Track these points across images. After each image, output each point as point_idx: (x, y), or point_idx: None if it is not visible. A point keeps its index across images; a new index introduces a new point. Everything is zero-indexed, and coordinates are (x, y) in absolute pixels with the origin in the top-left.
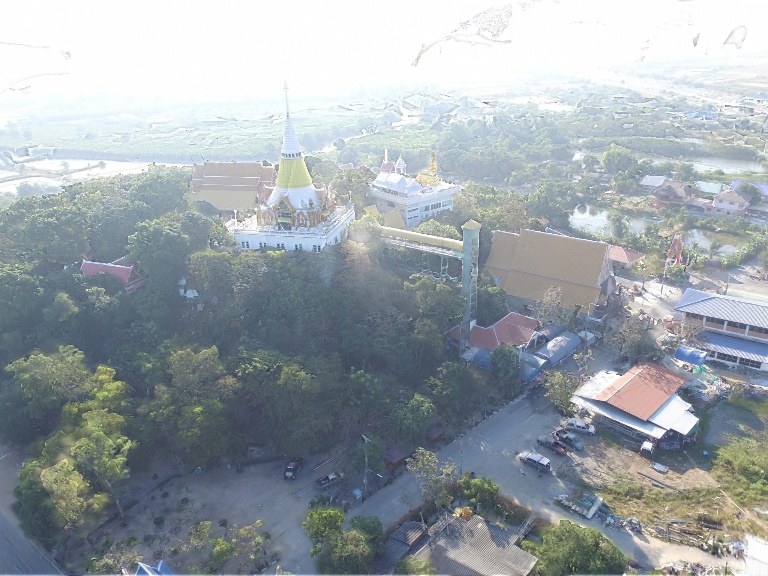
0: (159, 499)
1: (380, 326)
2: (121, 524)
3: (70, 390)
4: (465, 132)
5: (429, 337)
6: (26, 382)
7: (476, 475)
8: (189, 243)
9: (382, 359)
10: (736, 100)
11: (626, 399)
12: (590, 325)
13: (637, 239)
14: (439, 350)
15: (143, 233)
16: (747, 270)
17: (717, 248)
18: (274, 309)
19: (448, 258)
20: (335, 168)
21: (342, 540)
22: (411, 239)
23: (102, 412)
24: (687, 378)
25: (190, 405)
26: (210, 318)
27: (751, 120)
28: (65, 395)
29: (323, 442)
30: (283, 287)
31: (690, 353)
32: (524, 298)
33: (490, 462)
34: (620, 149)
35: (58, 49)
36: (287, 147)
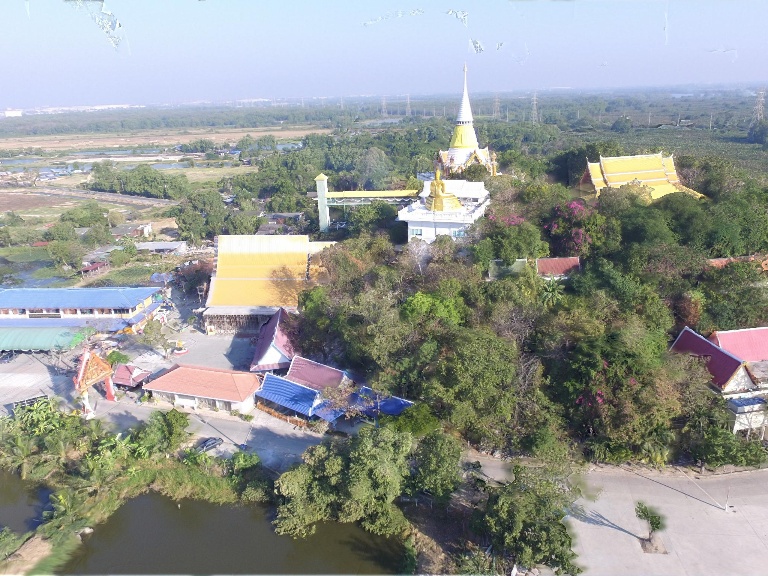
0: None
1: None
2: None
3: None
4: None
5: None
6: None
7: None
8: None
9: None
10: None
11: None
12: None
13: None
14: None
15: None
16: None
17: None
18: None
19: None
20: None
21: None
22: None
23: None
24: None
25: None
26: None
27: None
28: None
29: None
30: None
31: None
32: None
33: None
34: None
35: None
36: None
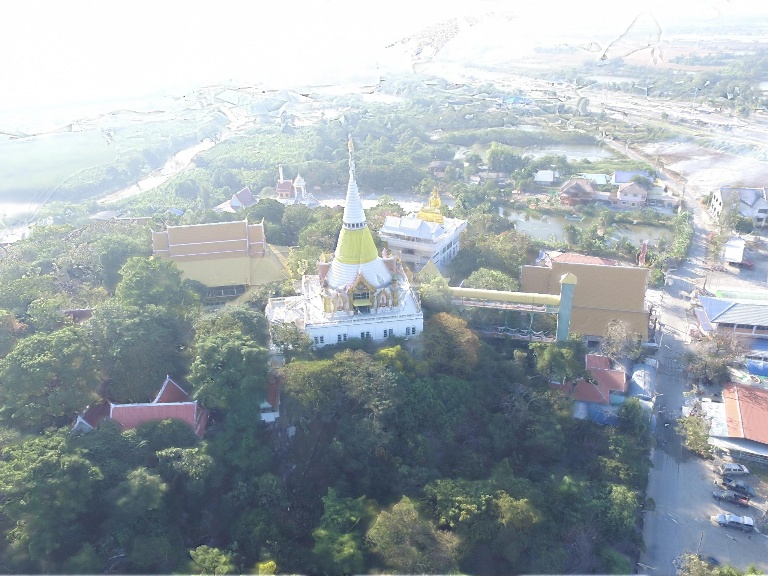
0: None
1: (521, 410)
2: None
3: None
4: (327, 135)
5: (571, 411)
6: None
7: (703, 557)
8: None
9: (528, 446)
10: (535, 84)
11: (756, 430)
12: (645, 350)
13: (593, 244)
14: (574, 420)
15: (217, 358)
16: (696, 262)
17: (665, 245)
18: (411, 420)
19: None
20: (308, 212)
21: None
22: (492, 299)
23: None
24: None
25: None
26: (341, 451)
27: (566, 104)
28: None
29: None
30: (416, 392)
31: (763, 367)
32: None
33: (696, 536)
34: (502, 147)
35: (98, 131)
36: (354, 216)
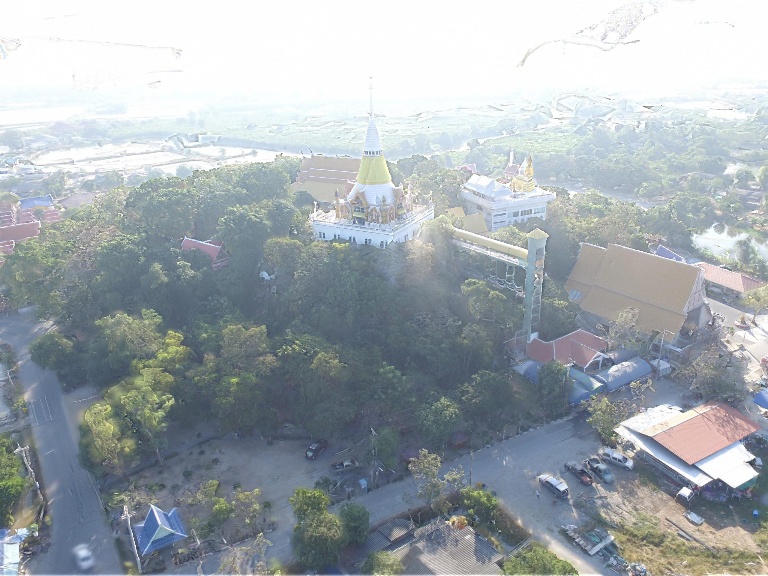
0: (196, 455)
1: (428, 326)
2: (158, 471)
3: (140, 348)
4: (609, 138)
5: (475, 343)
6: (108, 336)
7: (487, 488)
8: (273, 229)
9: None
10: None
11: (676, 438)
12: (669, 354)
13: (765, 267)
14: (485, 358)
15: (230, 217)
16: None
17: None
18: (331, 298)
19: (517, 266)
20: (437, 168)
21: (318, 521)
22: (480, 243)
23: (157, 370)
24: (767, 427)
25: (230, 375)
26: (274, 300)
27: None
28: (135, 352)
29: (344, 429)
30: (341, 278)
31: None
32: (602, 316)
33: (507, 478)
34: None
35: (170, 49)
36: (368, 145)
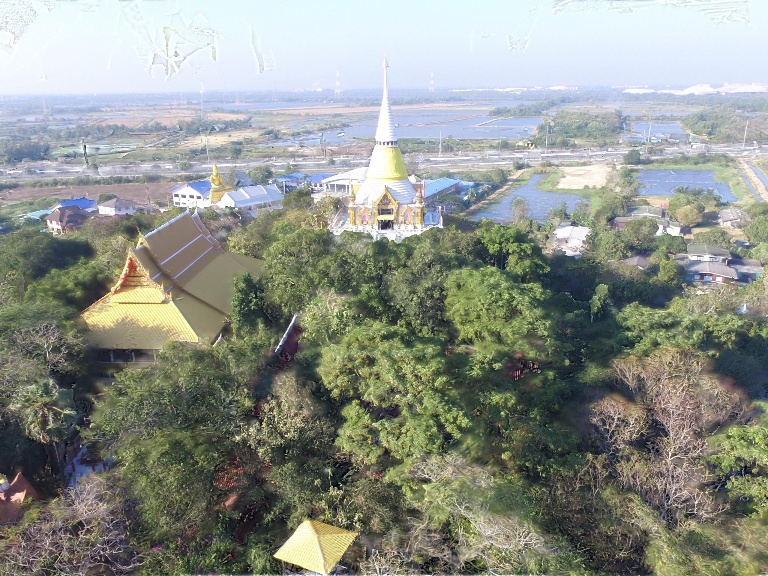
0: None
1: None
2: None
3: None
4: None
5: None
6: None
7: None
8: None
9: None
10: None
11: None
12: None
13: None
14: None
15: None
16: None
17: None
18: None
19: None
20: None
21: None
22: None
23: None
24: None
25: None
26: None
27: None
28: None
29: None
30: None
31: None
32: None
33: None
34: None
35: None
36: None
